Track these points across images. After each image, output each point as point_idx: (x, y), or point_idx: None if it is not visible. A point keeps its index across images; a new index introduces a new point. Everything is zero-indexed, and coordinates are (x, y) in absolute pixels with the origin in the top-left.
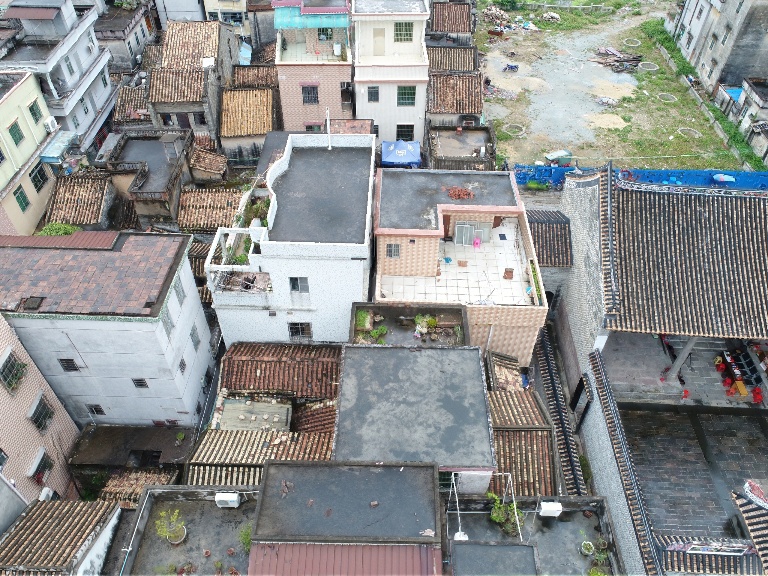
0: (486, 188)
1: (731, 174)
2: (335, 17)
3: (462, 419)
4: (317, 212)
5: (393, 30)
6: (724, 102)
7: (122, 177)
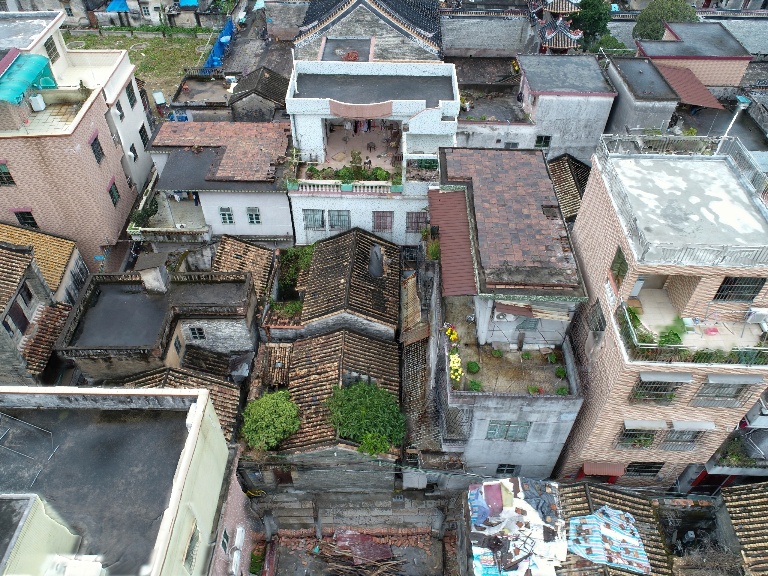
0: (344, 48)
1: (222, 35)
2: (24, 62)
3: (569, 61)
4: (399, 94)
5: (45, 52)
6: (114, 19)
7: (169, 351)
